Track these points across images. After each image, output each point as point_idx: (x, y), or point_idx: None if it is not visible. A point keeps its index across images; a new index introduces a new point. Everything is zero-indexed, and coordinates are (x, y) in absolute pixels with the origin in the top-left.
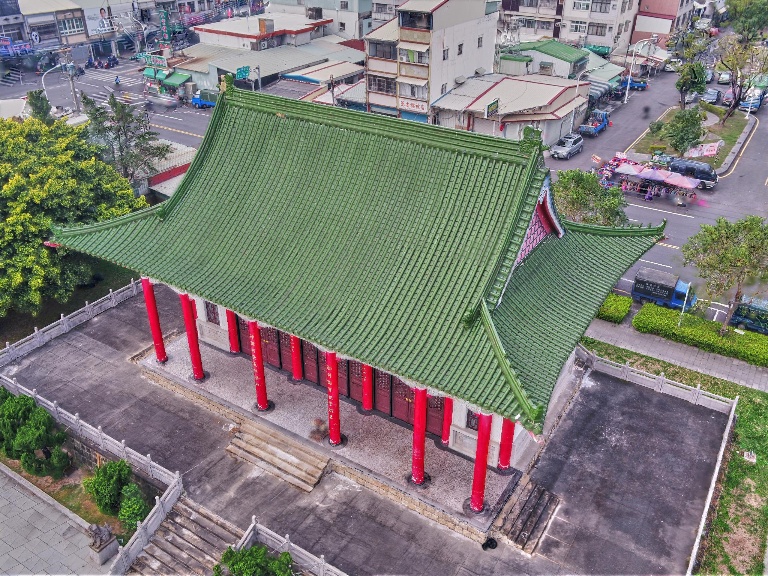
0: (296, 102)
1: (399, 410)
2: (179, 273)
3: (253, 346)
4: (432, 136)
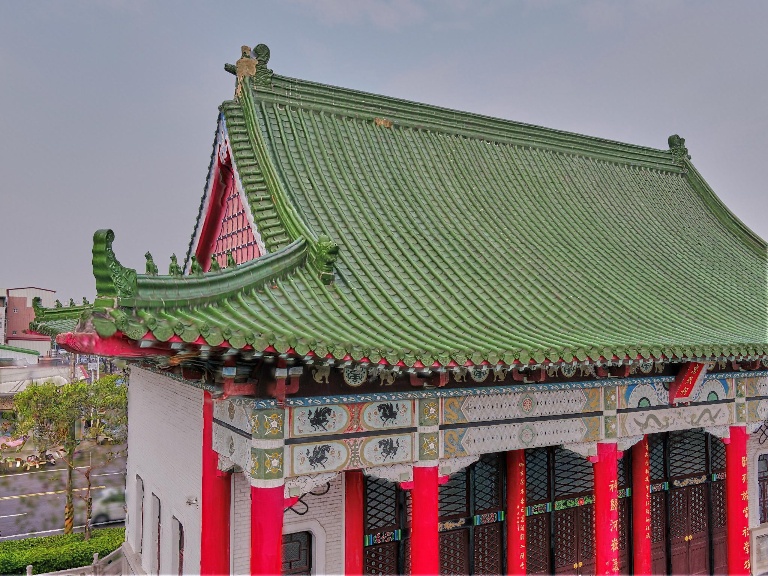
0: (409, 102)
1: (677, 571)
2: (546, 339)
3: (615, 511)
4: (597, 148)
